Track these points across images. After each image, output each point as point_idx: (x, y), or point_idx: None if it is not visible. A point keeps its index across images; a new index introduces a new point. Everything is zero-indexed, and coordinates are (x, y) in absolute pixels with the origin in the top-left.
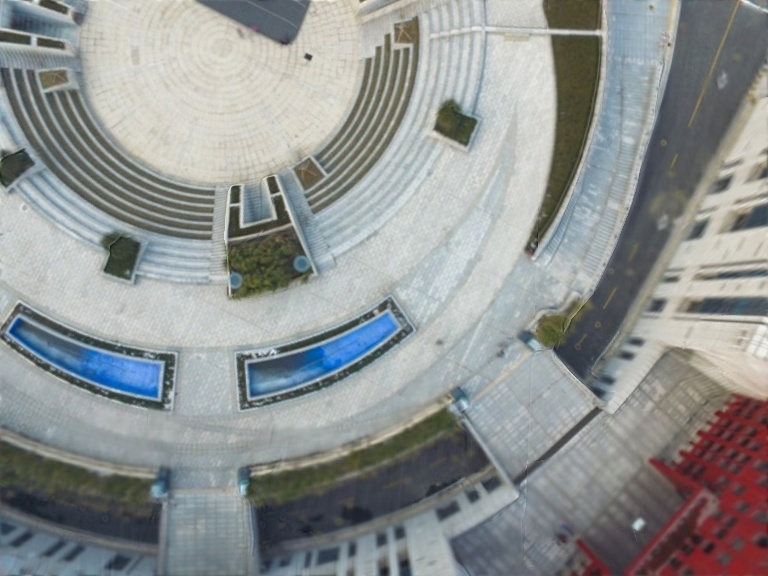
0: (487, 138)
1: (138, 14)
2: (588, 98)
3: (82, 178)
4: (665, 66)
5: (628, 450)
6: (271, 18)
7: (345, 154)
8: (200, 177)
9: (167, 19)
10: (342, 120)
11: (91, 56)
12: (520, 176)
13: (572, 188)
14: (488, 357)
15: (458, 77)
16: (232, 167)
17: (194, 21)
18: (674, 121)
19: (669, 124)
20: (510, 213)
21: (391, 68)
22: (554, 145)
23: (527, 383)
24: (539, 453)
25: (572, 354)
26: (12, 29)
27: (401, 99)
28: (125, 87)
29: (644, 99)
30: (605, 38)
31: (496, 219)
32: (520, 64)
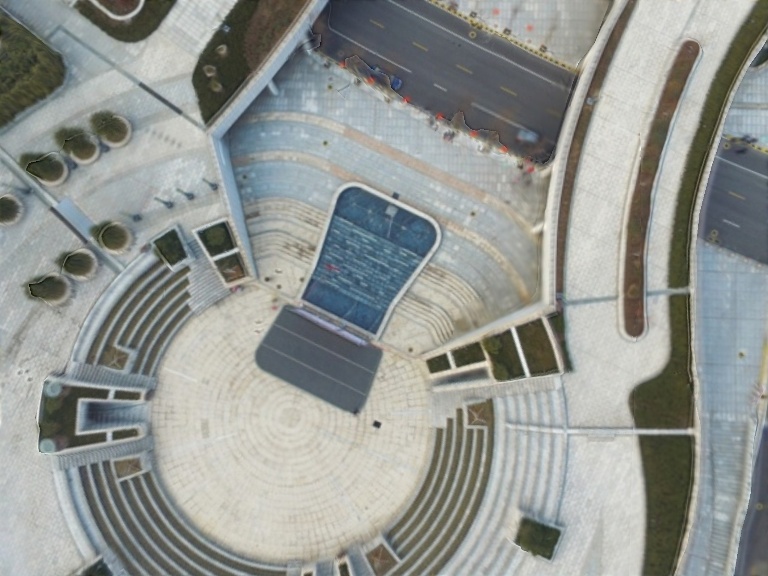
0: (571, 546)
1: (207, 386)
2: (681, 505)
3: (157, 574)
4: (759, 421)
5: None
6: (339, 387)
7: (418, 538)
8: (271, 553)
9: (235, 390)
10: (413, 493)
11: (162, 431)
12: None
13: None
14: None
15: (538, 477)
16: (302, 542)
17: (262, 391)
18: None
19: (765, 486)
20: None
21: (464, 447)
22: (644, 554)
23: None
24: None
25: None
26: (89, 430)
27: (476, 485)
28: (196, 461)
29: (737, 466)
30: (698, 438)
31: None
32: (605, 466)
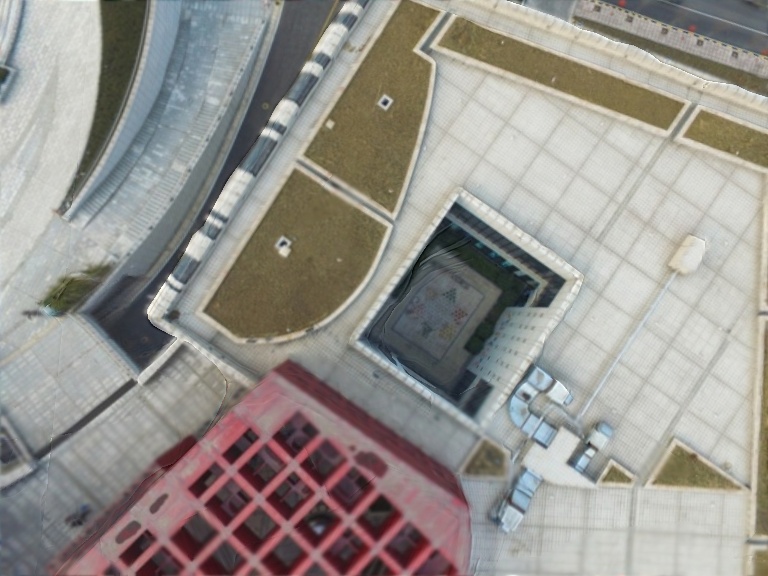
0: (24, 91)
1: None
2: (133, 51)
3: None
4: (271, 26)
5: (166, 425)
6: None
7: None
8: None
9: None
10: None
11: None
12: (59, 132)
13: (111, 145)
14: (14, 322)
15: None
16: None
17: None
18: (278, 84)
19: (272, 87)
20: (46, 170)
21: None
22: (97, 100)
23: (56, 351)
24: (66, 426)
25: (152, 325)
26: None
27: None
28: None
29: (238, 59)
30: None
31: (30, 176)
32: (64, 14)
